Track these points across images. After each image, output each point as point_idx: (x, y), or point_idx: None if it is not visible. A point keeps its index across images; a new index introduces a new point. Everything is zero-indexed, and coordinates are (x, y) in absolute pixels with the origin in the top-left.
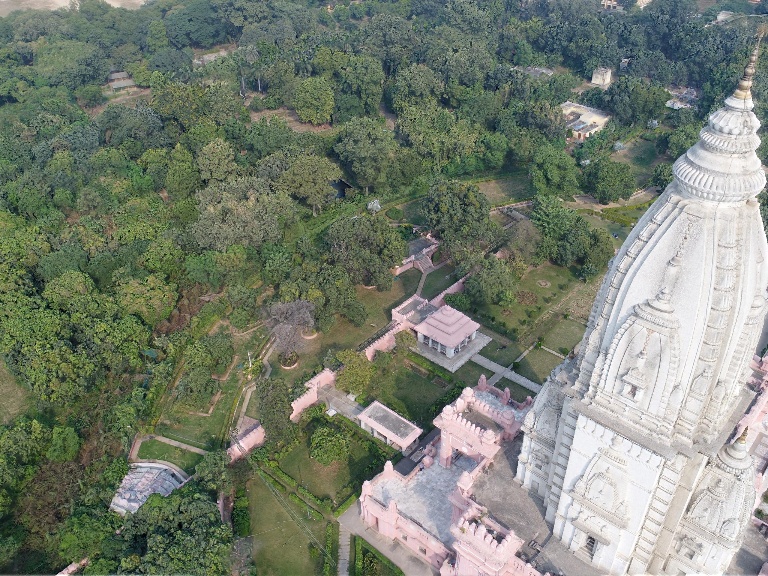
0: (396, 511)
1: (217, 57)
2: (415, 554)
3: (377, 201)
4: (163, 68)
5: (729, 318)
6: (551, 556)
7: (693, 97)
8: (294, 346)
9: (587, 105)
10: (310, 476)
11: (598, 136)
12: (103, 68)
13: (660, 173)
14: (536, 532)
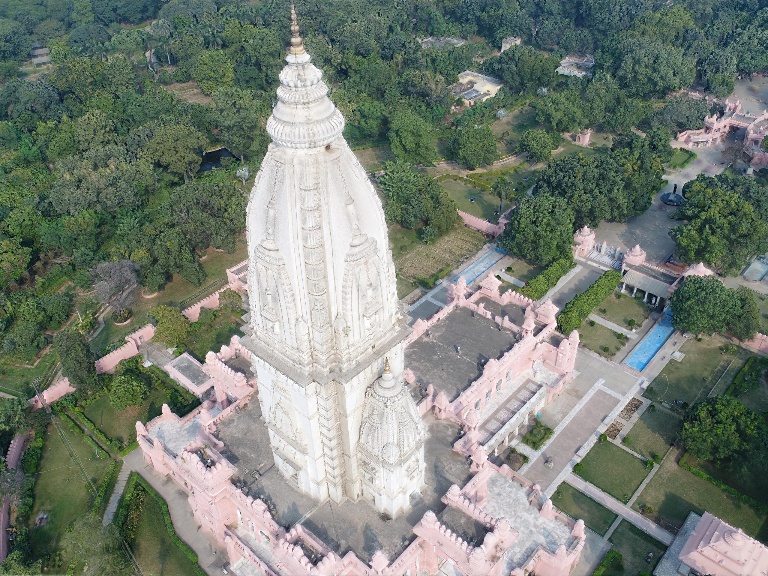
0: (162, 448)
1: (122, 31)
2: (182, 488)
3: (246, 169)
4: (81, 43)
5: (323, 255)
6: (265, 483)
7: (591, 65)
8: (131, 304)
9: (485, 74)
10: (110, 420)
11: (481, 104)
12: (24, 44)
13: (525, 139)
14: (262, 463)
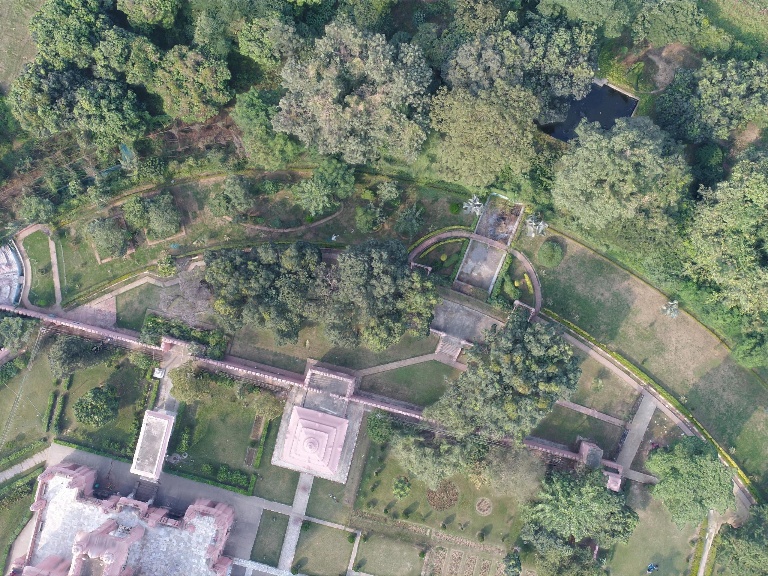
0: None
1: None
2: None
3: (543, 226)
4: None
5: None
6: None
7: None
8: None
9: None
10: None
11: None
12: None
13: None
14: None
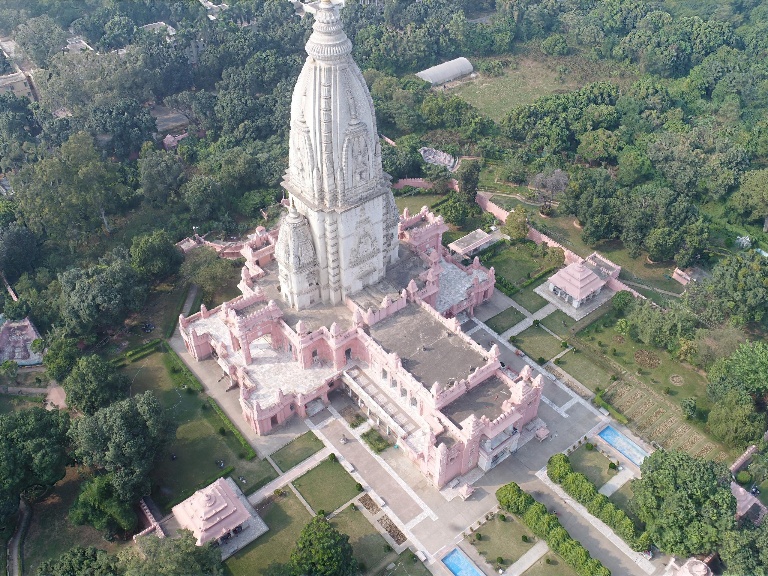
0: None
1: None
2: None
3: None
4: None
5: None
6: None
7: None
8: None
9: None
10: None
11: None
12: None
13: None
14: None
